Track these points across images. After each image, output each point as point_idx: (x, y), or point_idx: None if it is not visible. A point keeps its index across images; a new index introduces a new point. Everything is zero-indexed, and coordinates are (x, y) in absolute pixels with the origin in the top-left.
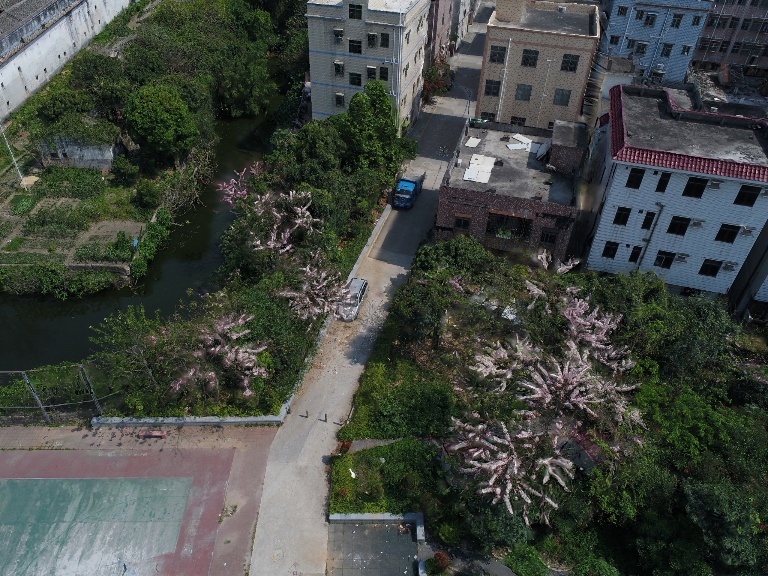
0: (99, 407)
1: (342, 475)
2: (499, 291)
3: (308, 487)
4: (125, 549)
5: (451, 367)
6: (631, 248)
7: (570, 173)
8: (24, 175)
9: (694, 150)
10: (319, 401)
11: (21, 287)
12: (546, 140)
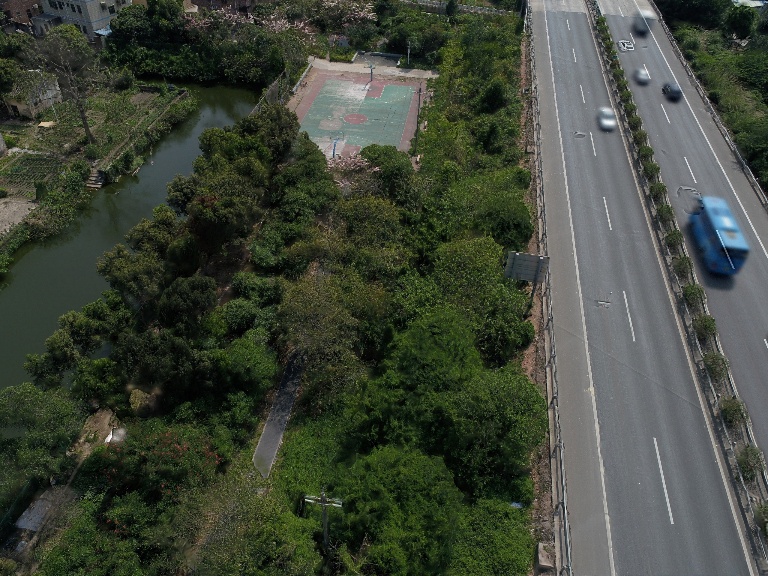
0: None
1: None
2: None
3: None
4: (349, 87)
5: None
6: None
7: None
8: (33, 127)
9: None
10: None
11: (182, 115)
12: None
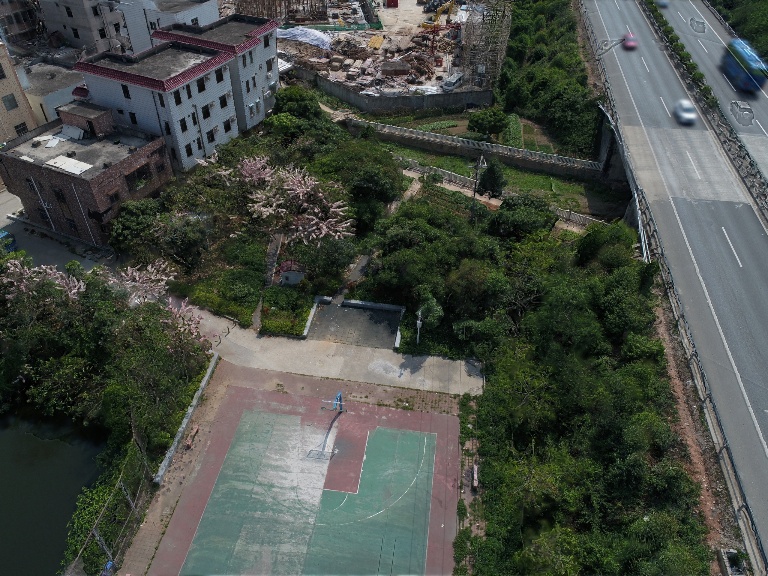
0: (149, 470)
1: (279, 325)
2: (210, 191)
3: (277, 347)
4: (289, 445)
5: (214, 265)
6: (196, 141)
7: (113, 132)
8: None
9: (176, 69)
10: (209, 334)
11: None
12: (56, 130)
